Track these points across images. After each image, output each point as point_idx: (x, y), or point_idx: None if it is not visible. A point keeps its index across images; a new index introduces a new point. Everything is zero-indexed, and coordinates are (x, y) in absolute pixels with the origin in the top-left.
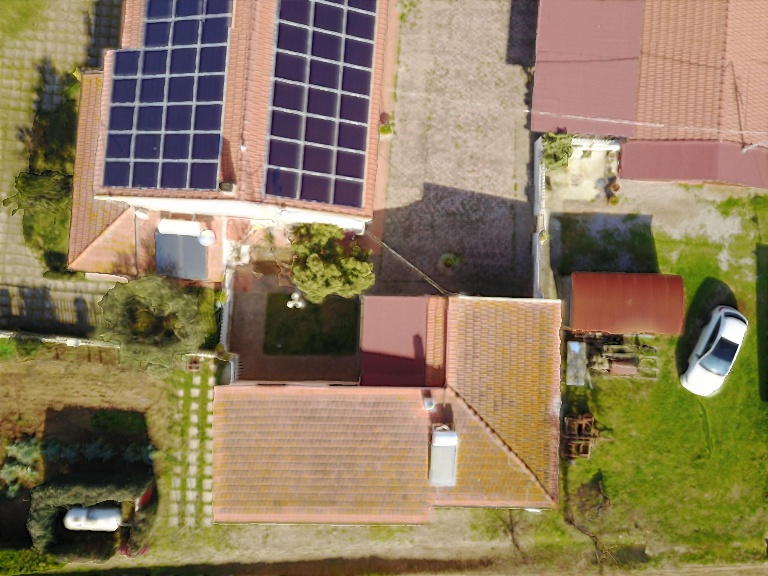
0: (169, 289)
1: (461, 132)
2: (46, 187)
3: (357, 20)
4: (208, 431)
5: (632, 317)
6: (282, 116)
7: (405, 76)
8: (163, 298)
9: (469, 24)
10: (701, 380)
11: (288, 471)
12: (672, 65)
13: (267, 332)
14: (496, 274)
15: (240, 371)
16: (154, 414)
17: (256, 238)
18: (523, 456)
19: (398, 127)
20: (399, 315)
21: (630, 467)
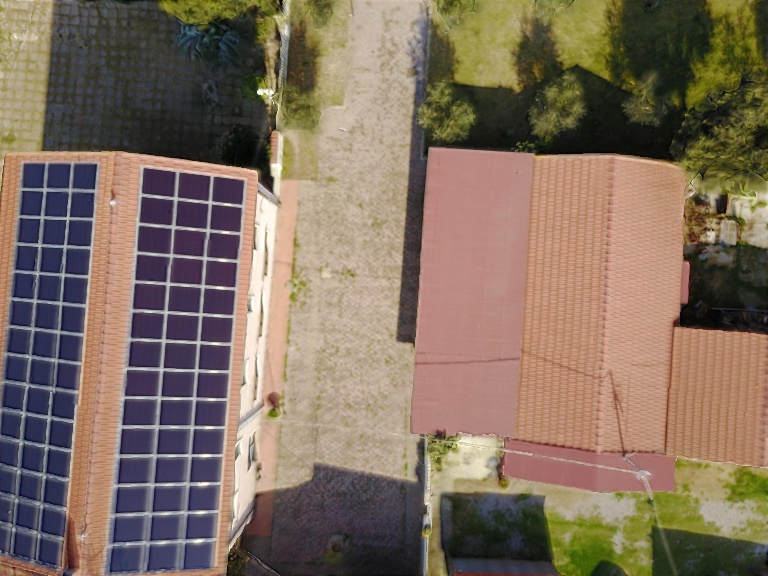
0: None
1: (351, 411)
2: None
3: (209, 380)
4: None
5: None
6: (128, 491)
7: (295, 355)
8: None
9: (359, 302)
10: None
11: None
12: (552, 368)
13: None
14: (386, 555)
15: None
16: None
17: None
18: None
19: (288, 406)
20: None
21: None
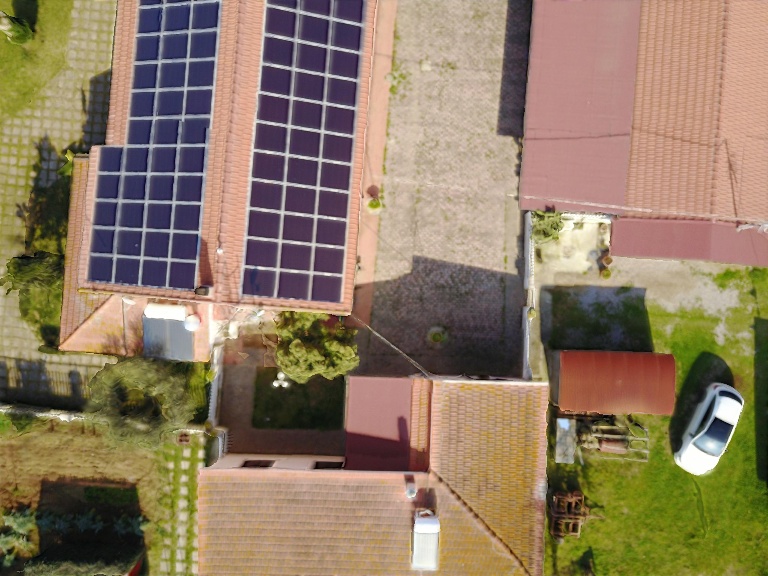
0: (156, 372)
1: (450, 204)
2: (38, 270)
3: (336, 115)
4: None
5: (622, 398)
6: (259, 216)
7: (394, 148)
8: (150, 381)
9: (459, 95)
10: (695, 460)
11: (272, 552)
12: (664, 142)
13: (256, 405)
14: (485, 348)
15: (229, 443)
16: (146, 485)
17: (245, 313)
18: (508, 541)
19: (387, 200)
20: (384, 396)
21: (622, 545)
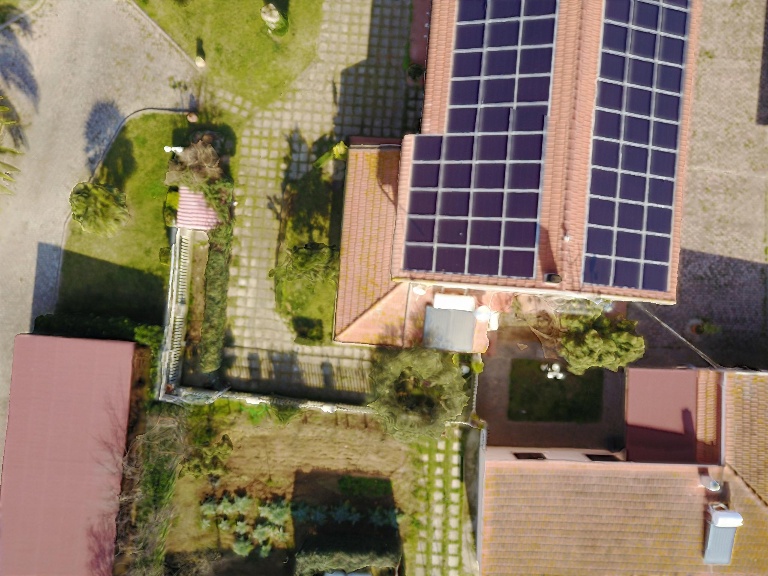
0: (441, 362)
1: (709, 195)
2: (318, 261)
3: (663, 102)
4: (453, 495)
5: None
6: (597, 203)
7: None
8: (436, 372)
9: (717, 84)
10: None
11: (558, 546)
12: None
13: (511, 397)
14: (746, 340)
15: None
16: (399, 477)
17: None
18: None
19: None
20: (666, 388)
21: None
